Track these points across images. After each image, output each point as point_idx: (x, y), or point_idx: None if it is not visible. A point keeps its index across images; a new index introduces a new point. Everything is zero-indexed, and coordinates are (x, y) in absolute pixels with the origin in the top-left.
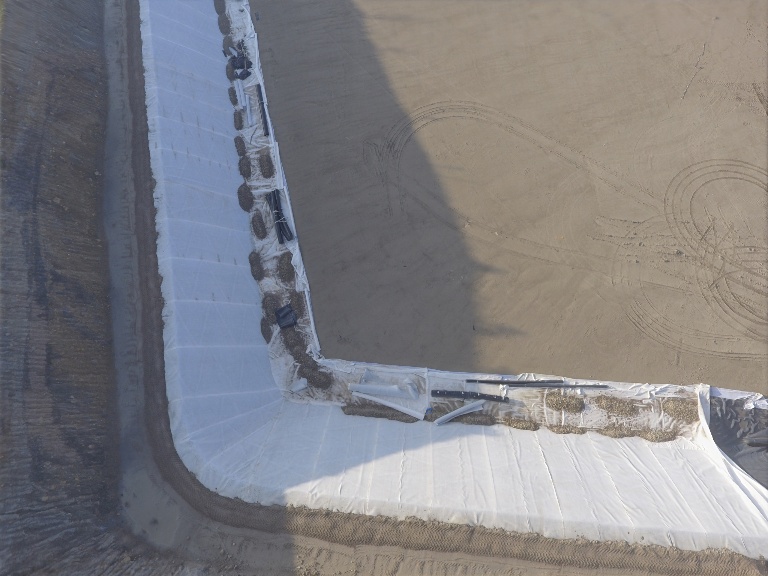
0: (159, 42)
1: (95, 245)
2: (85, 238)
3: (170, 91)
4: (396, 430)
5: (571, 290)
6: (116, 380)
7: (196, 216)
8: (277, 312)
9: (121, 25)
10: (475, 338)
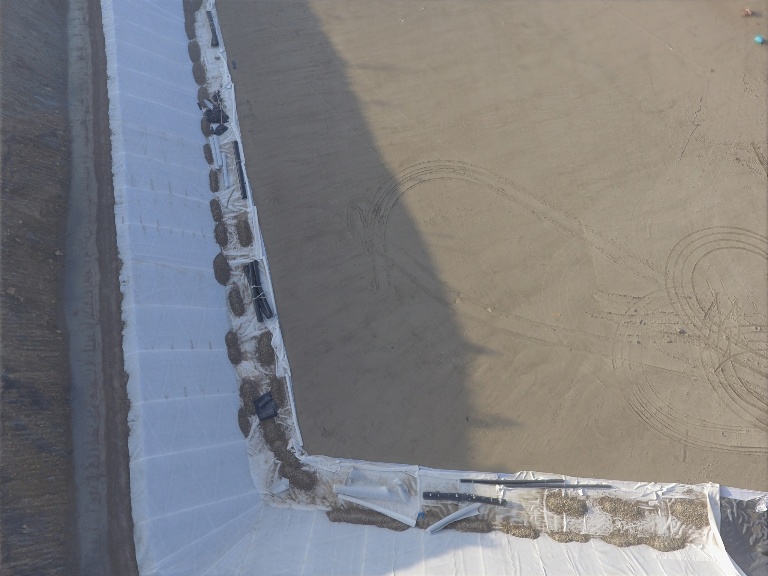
0: (127, 100)
1: (54, 338)
2: (43, 331)
3: (139, 155)
4: (385, 542)
5: (570, 375)
6: (76, 498)
7: (167, 298)
8: (256, 402)
9: (86, 81)
10: (469, 430)
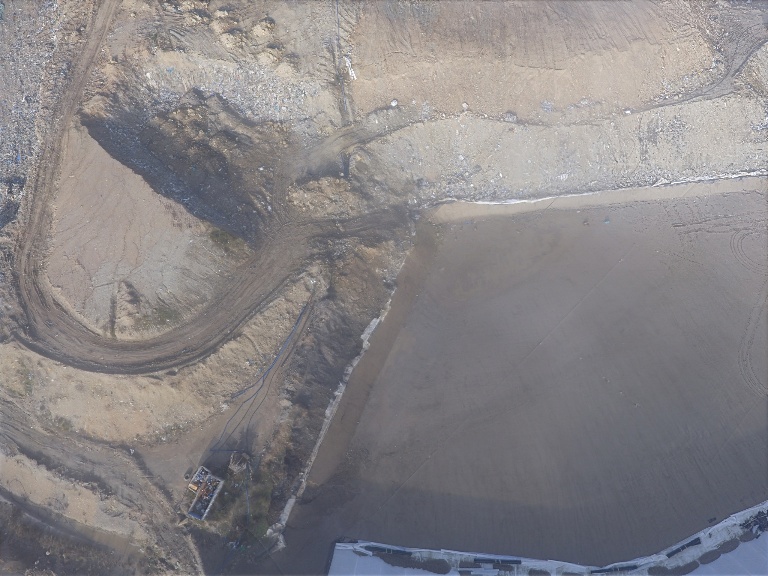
0: None
1: None
2: None
3: None
4: None
5: None
6: None
7: None
8: None
9: None
10: None
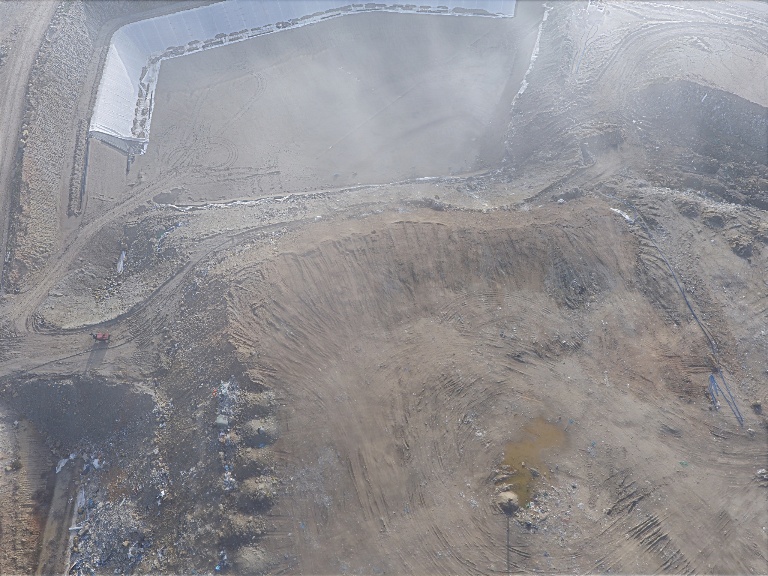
0: None
1: None
2: None
3: (251, 3)
4: None
5: (183, 113)
6: (144, 11)
7: (201, 19)
8: (176, 49)
9: None
10: (166, 92)
